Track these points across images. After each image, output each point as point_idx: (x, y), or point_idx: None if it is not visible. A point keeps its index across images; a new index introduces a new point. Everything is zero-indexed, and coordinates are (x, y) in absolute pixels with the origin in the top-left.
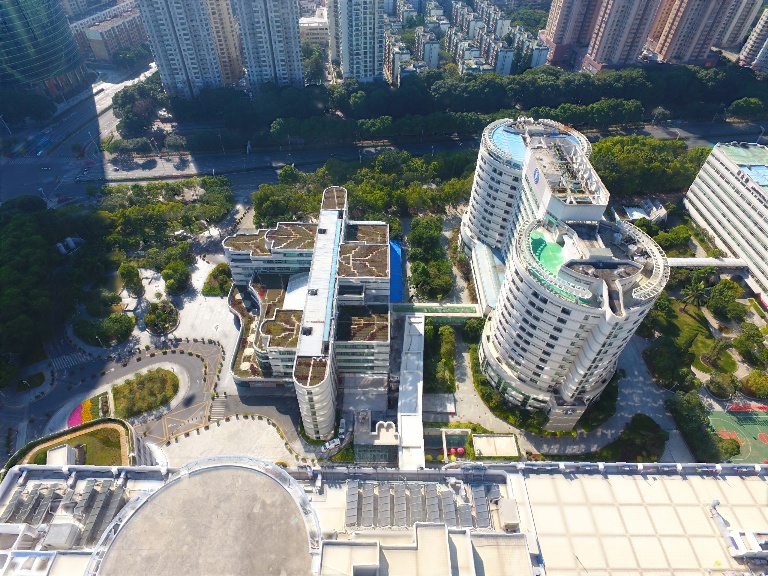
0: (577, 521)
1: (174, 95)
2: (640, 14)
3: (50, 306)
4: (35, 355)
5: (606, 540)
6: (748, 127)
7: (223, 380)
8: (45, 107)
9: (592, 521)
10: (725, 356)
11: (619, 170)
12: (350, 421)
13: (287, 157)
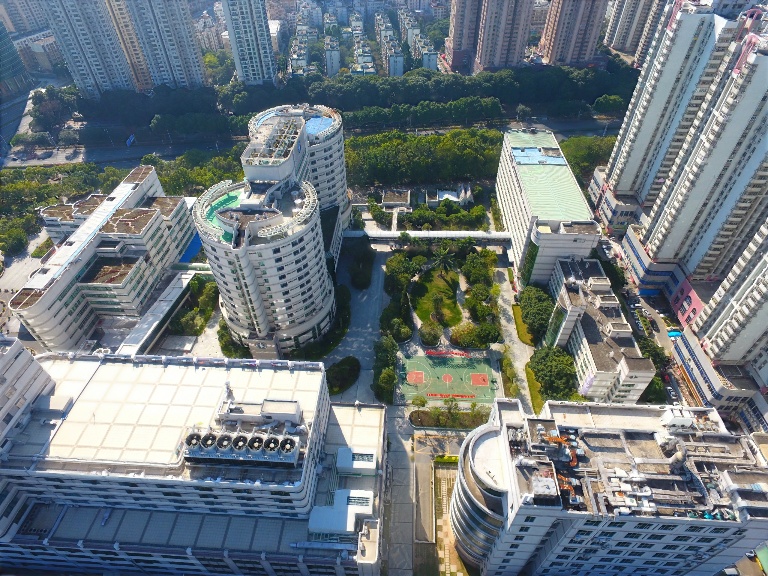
0: (116, 393)
1: (89, 98)
2: (510, 19)
3: None
4: None
5: (127, 406)
6: (611, 123)
7: (12, 321)
8: None
9: (127, 394)
10: (455, 313)
11: (435, 157)
12: None
13: (166, 149)
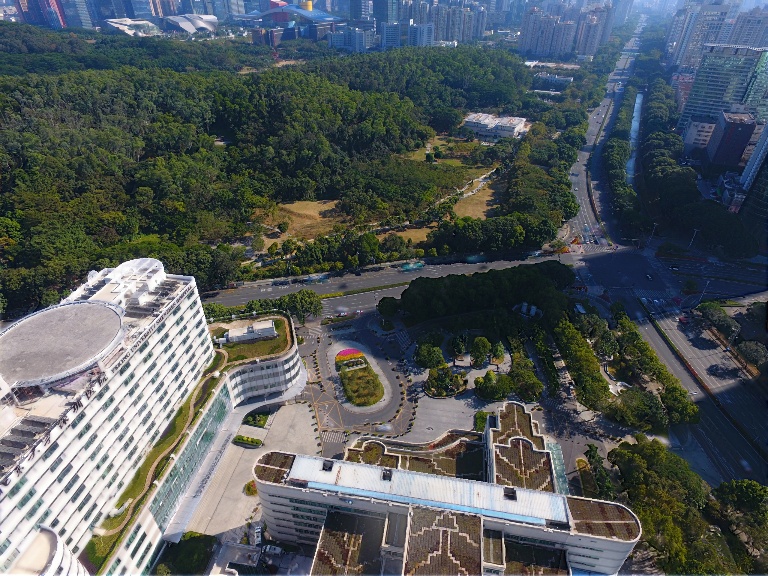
0: None
1: None
2: None
3: (439, 310)
4: (410, 321)
5: None
6: None
7: None
8: (742, 248)
9: None
10: None
11: None
12: (281, 563)
13: None
